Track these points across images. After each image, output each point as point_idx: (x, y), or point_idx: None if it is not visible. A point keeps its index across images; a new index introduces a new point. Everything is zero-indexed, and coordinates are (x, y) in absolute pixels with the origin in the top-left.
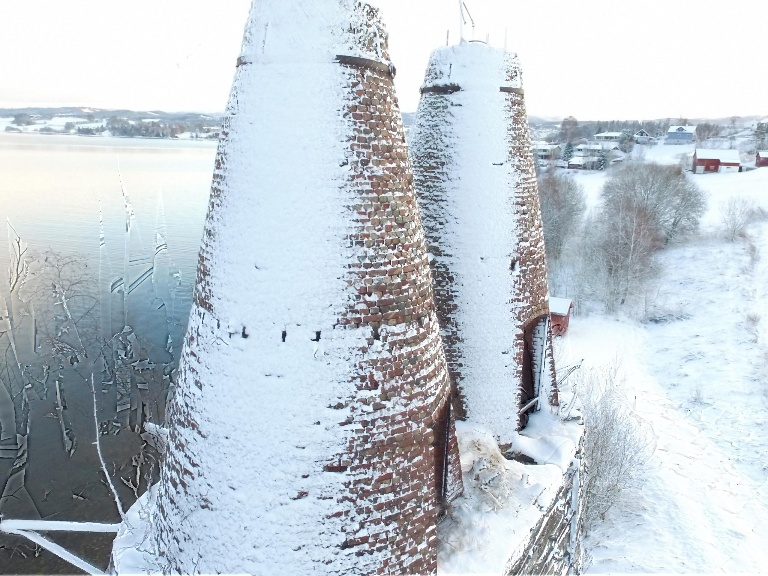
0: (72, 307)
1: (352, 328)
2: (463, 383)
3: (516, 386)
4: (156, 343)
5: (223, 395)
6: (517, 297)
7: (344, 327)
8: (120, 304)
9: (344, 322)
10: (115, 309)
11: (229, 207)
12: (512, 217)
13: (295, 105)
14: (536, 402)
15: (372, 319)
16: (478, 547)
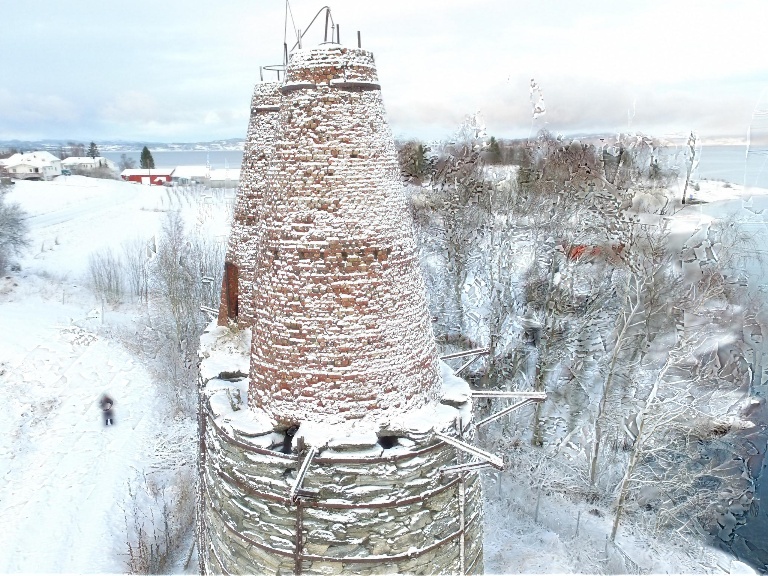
0: None
1: None
2: None
3: None
4: None
5: None
6: None
7: None
8: None
9: None
10: None
11: None
12: None
13: None
14: None
15: None
16: None
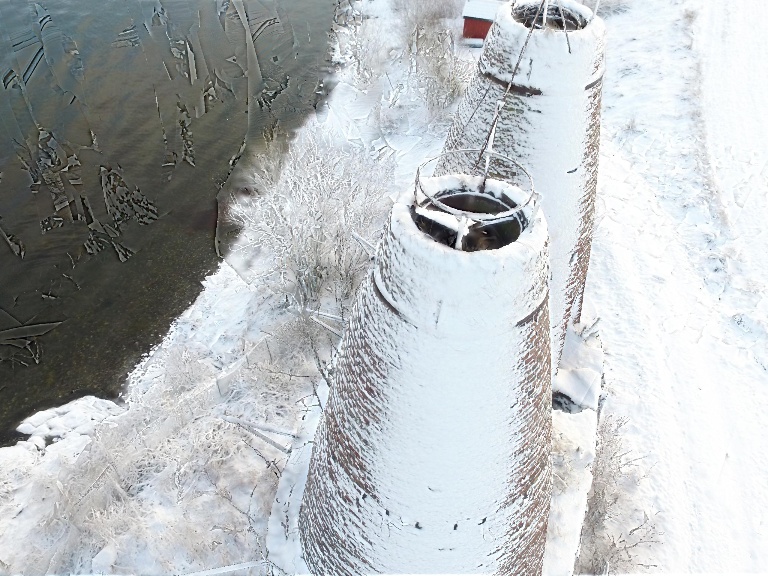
0: None
1: (510, 505)
2: None
3: (560, 346)
4: (80, 142)
5: (398, 557)
6: (572, 281)
7: (504, 508)
8: (20, 100)
9: (505, 505)
10: (16, 107)
11: (394, 440)
12: (578, 217)
13: (474, 377)
14: None
15: None
16: (559, 533)
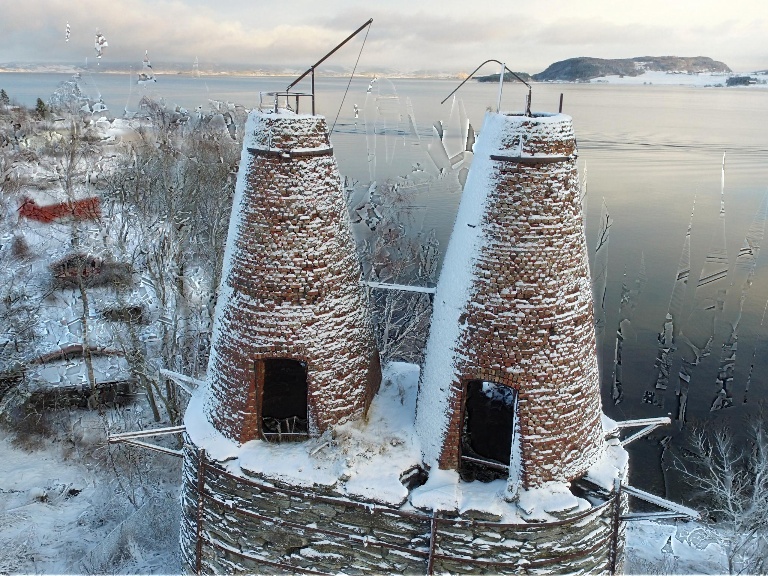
0: (647, 282)
1: None
2: (419, 396)
3: (445, 424)
4: (693, 340)
5: None
6: (461, 348)
7: None
8: (684, 293)
9: None
10: (678, 296)
11: None
12: (471, 276)
13: None
14: None
15: None
16: (276, 455)
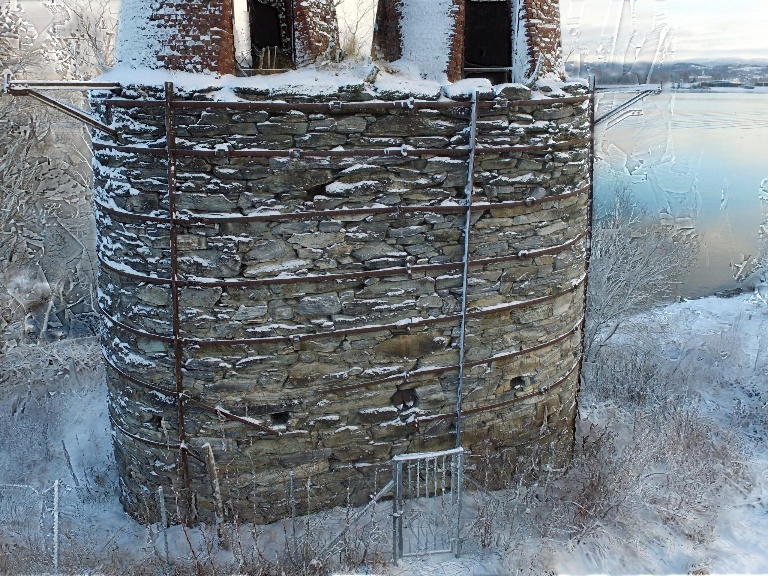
0: None
1: None
2: (403, 22)
3: (449, 26)
4: None
5: None
6: None
7: None
8: None
9: None
10: None
11: None
12: None
13: None
14: (511, 73)
15: None
16: (275, 75)
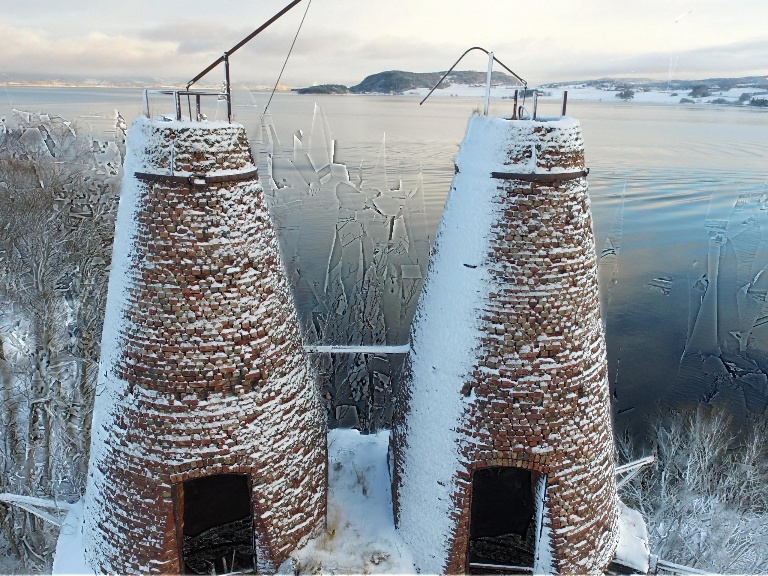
0: None
1: None
2: (401, 490)
3: (449, 528)
4: None
5: None
6: (466, 428)
7: (115, 375)
8: None
9: (115, 371)
10: None
11: None
12: (475, 333)
13: None
14: None
15: (130, 377)
16: None
